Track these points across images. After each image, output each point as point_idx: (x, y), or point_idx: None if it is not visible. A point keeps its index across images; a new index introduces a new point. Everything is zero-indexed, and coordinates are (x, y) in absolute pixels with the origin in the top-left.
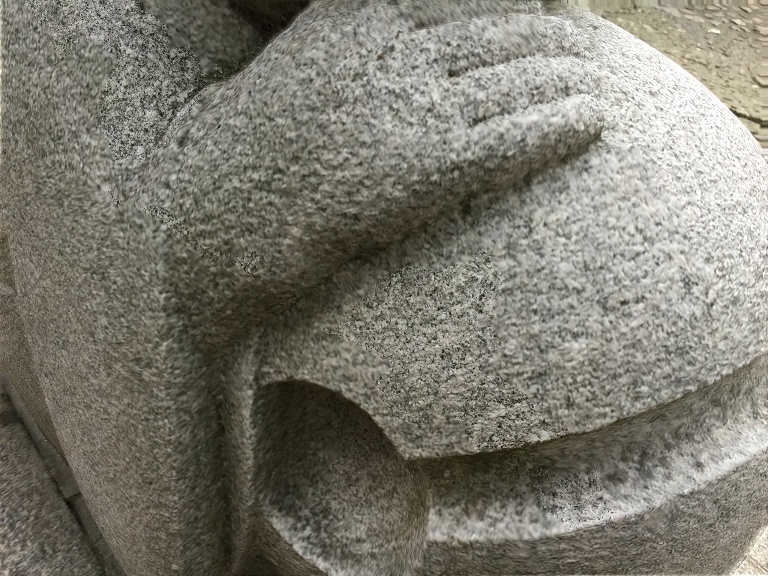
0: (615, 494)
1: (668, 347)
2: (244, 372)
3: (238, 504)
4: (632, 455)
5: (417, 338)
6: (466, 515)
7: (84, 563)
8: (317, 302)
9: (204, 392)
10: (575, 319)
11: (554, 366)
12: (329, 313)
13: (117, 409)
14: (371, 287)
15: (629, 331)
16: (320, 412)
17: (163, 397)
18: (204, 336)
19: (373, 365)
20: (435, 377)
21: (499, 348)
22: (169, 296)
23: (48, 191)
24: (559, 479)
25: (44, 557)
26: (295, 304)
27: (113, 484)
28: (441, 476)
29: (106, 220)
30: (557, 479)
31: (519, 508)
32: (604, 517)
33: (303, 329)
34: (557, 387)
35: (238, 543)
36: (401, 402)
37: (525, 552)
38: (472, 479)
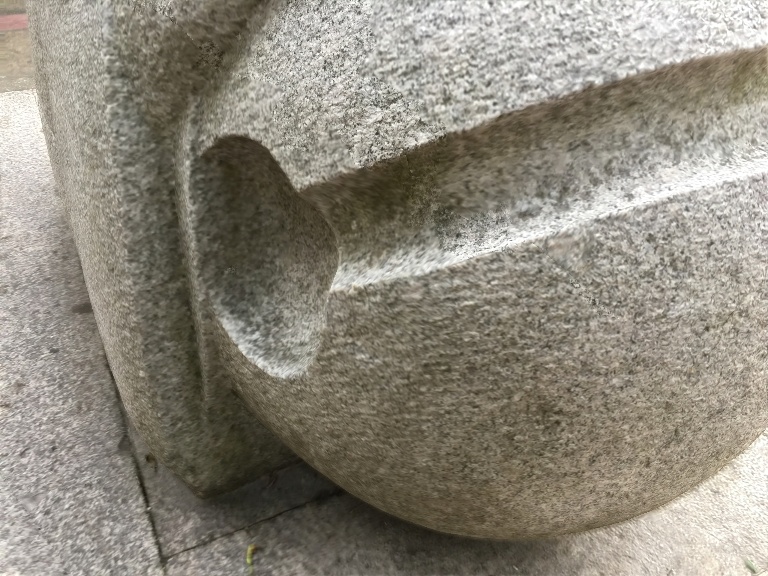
0: (521, 227)
1: (562, 31)
2: (184, 144)
3: (195, 305)
4: (549, 190)
5: (304, 54)
6: (368, 266)
7: (111, 422)
8: (235, 53)
9: (154, 171)
10: (451, 4)
11: (429, 57)
12: (241, 58)
13: (89, 196)
14: (272, 19)
15: (512, 12)
16: (273, 213)
17: (111, 165)
18: (148, 106)
19: (270, 95)
20: (318, 91)
21: (375, 46)
22: (113, 59)
23: (54, 8)
24: (465, 220)
25: (79, 412)
26: (220, 62)
27: (98, 290)
28: (349, 230)
29: (79, 8)
30: (463, 220)
31: (420, 252)
32: (501, 244)
33: (225, 85)
34: (433, 80)
35: (202, 357)
36: (292, 127)
37: (418, 292)
38: (378, 229)
